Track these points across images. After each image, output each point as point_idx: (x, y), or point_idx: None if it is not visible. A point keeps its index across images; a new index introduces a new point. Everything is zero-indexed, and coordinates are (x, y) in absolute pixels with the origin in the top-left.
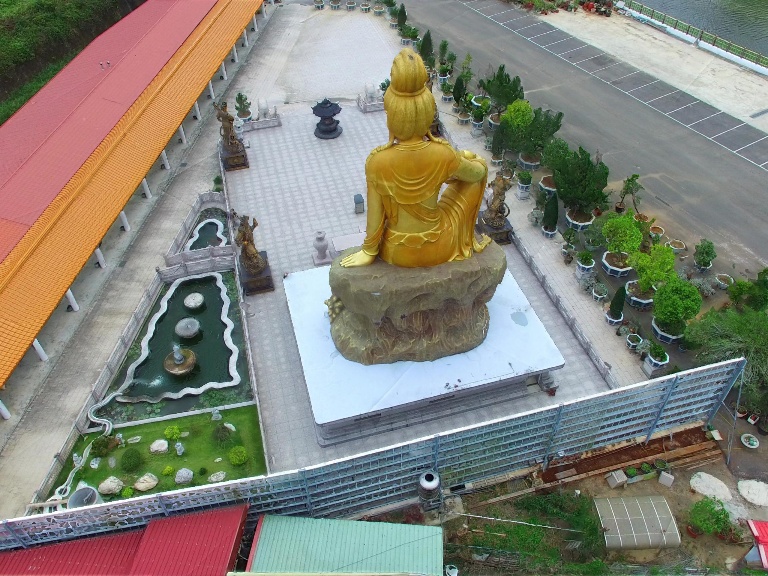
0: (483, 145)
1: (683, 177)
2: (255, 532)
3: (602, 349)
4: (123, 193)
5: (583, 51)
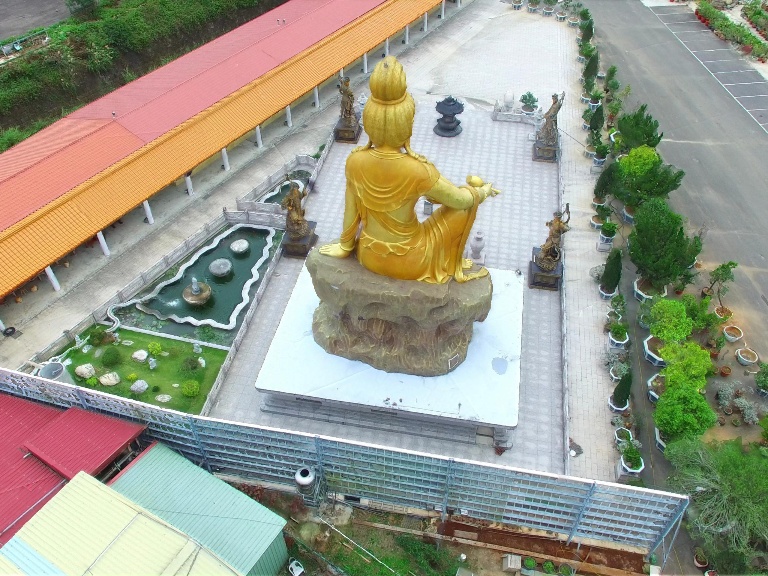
0: None
1: None
2: (142, 452)
3: (584, 431)
4: (228, 136)
5: None
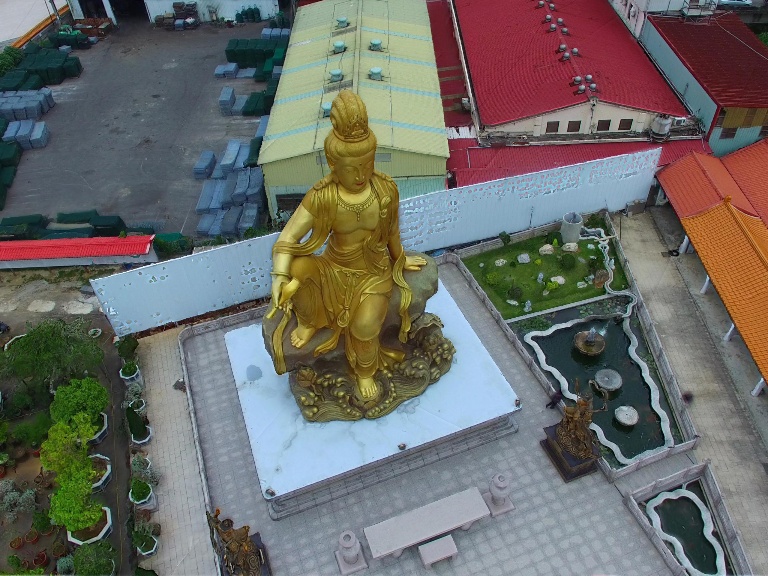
0: None
1: None
2: None
3: (174, 404)
4: None
5: None
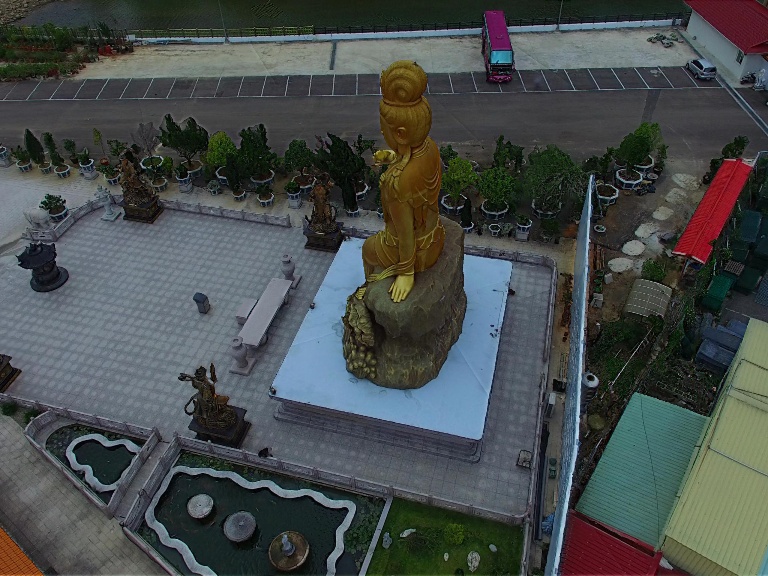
0: (206, 194)
1: (358, 127)
2: None
3: None
4: None
5: (158, 85)
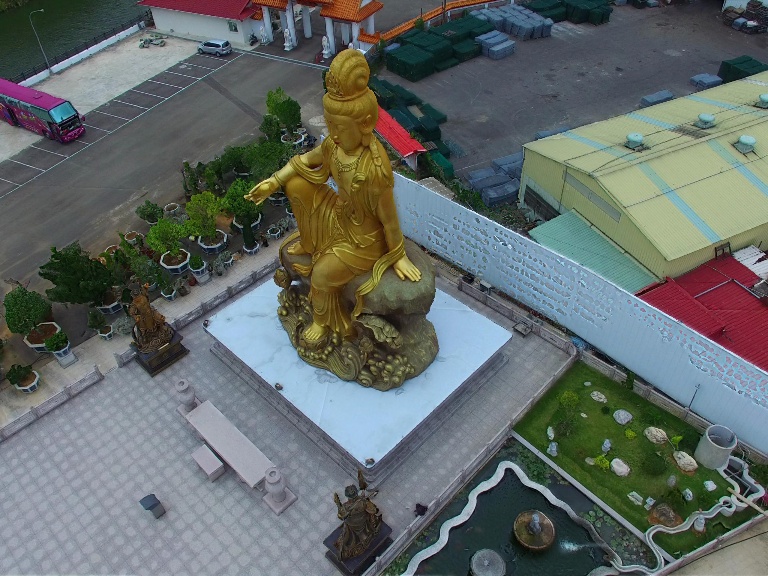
0: None
1: None
2: None
3: None
4: None
5: None
